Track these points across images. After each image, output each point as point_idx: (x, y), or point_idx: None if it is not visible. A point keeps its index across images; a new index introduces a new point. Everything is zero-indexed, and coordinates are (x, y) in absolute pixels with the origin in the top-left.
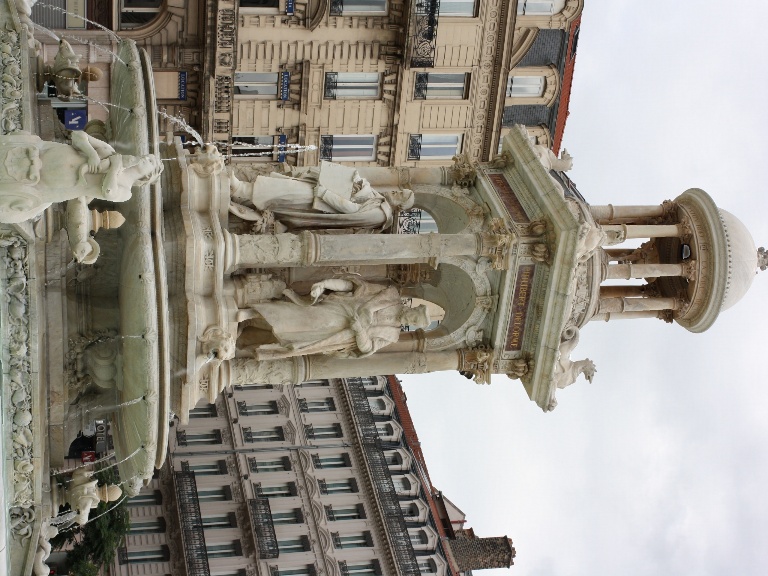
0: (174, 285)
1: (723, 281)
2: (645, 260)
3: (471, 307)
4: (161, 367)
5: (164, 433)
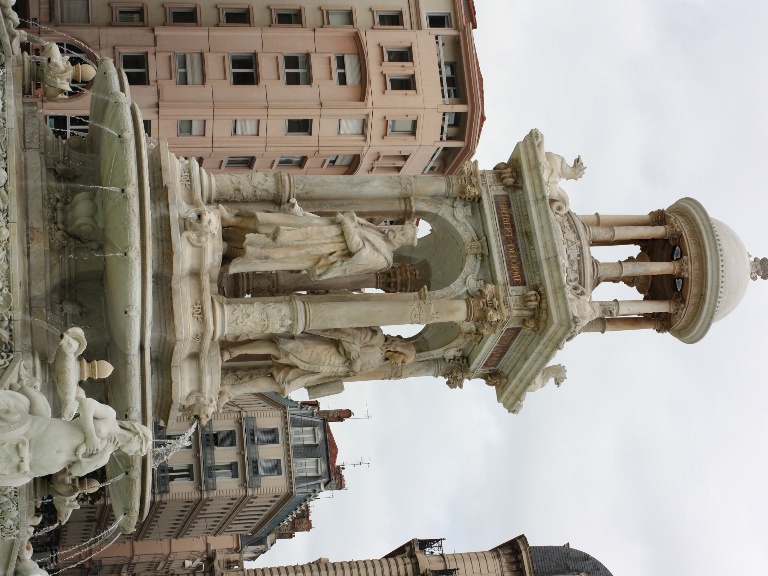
0: (153, 197)
1: (707, 222)
2: (634, 260)
3: (464, 262)
4: (136, 130)
5: (145, 186)
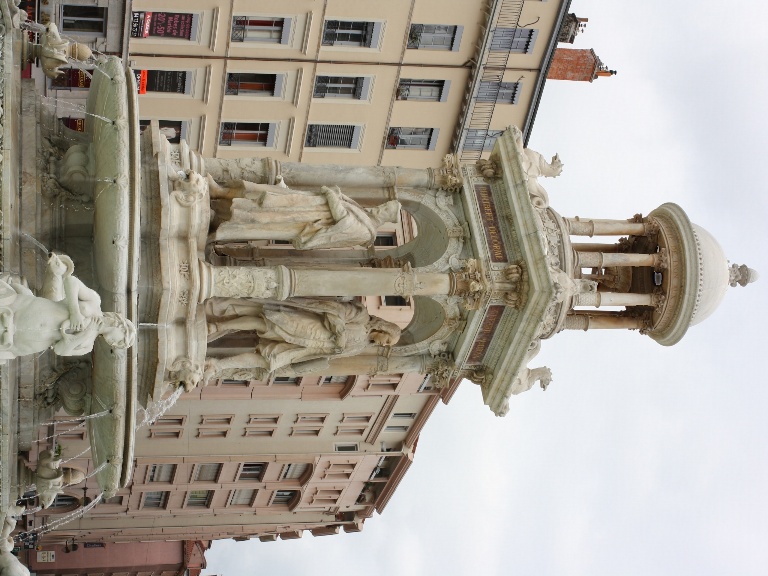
0: None
1: (683, 217)
2: None
3: None
4: (128, 80)
5: (135, 122)
